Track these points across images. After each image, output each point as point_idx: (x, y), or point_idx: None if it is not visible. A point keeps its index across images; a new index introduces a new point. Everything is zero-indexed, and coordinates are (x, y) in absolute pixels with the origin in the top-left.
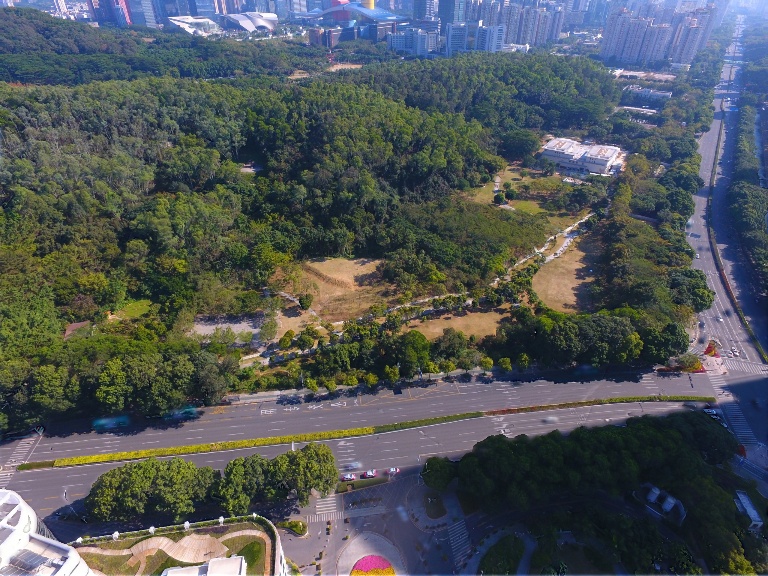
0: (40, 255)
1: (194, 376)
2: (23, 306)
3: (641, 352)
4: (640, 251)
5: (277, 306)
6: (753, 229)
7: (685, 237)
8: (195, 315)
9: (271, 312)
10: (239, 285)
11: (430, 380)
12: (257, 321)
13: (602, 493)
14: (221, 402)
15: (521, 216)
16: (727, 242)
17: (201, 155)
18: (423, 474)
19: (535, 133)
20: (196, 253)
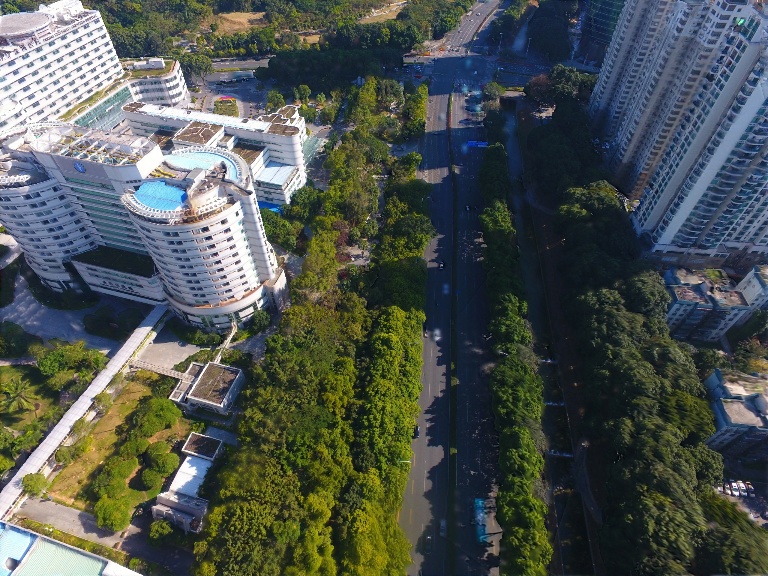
0: None
1: (146, 39)
2: None
3: (390, 40)
4: (429, 3)
5: (196, 28)
6: None
7: (473, 2)
8: None
9: (193, 30)
10: (175, 20)
11: None
12: None
13: None
14: None
15: None
16: None
17: None
18: (254, 72)
19: None
20: (147, 1)
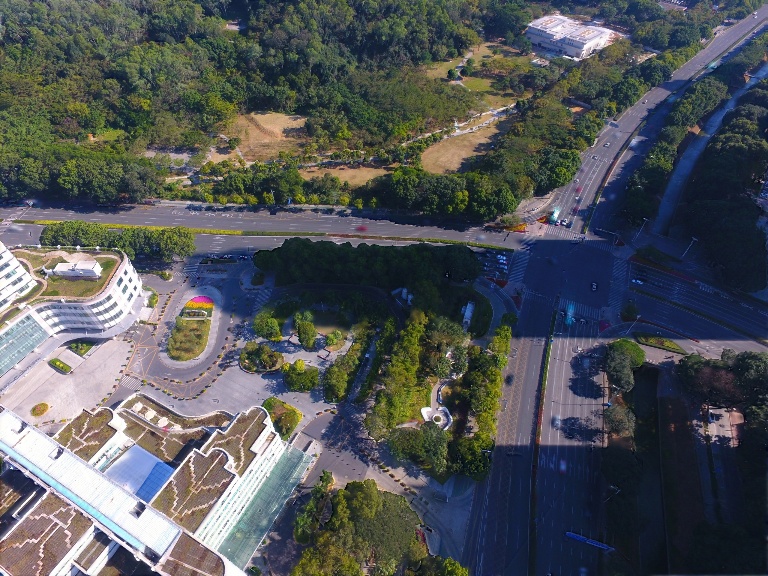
0: (44, 85)
1: (123, 178)
2: (24, 120)
3: (467, 207)
4: (536, 131)
5: (210, 143)
6: (676, 124)
7: (602, 125)
8: (152, 145)
9: (204, 147)
10: (188, 125)
11: (301, 209)
12: (195, 154)
13: (375, 290)
14: (148, 203)
15: (456, 91)
16: (650, 135)
17: (185, 9)
18: (252, 258)
19: (541, 8)
20: (159, 95)
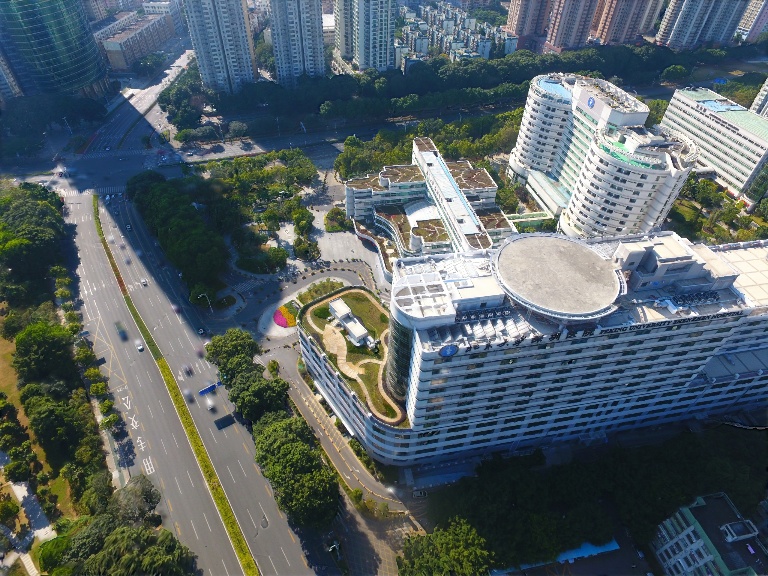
0: None
1: None
2: None
3: None
4: None
5: None
6: None
7: None
8: None
9: None
10: None
11: None
12: None
13: None
14: None
15: None
16: None
17: None
18: None
19: None
20: None
